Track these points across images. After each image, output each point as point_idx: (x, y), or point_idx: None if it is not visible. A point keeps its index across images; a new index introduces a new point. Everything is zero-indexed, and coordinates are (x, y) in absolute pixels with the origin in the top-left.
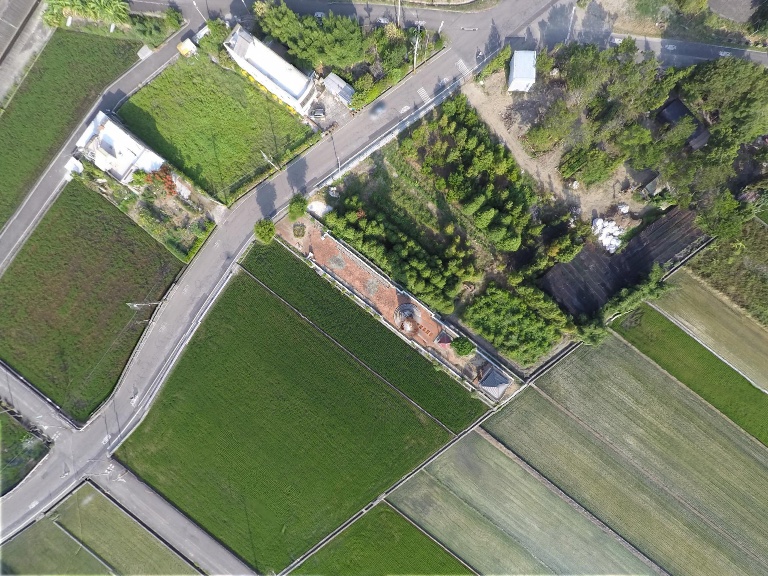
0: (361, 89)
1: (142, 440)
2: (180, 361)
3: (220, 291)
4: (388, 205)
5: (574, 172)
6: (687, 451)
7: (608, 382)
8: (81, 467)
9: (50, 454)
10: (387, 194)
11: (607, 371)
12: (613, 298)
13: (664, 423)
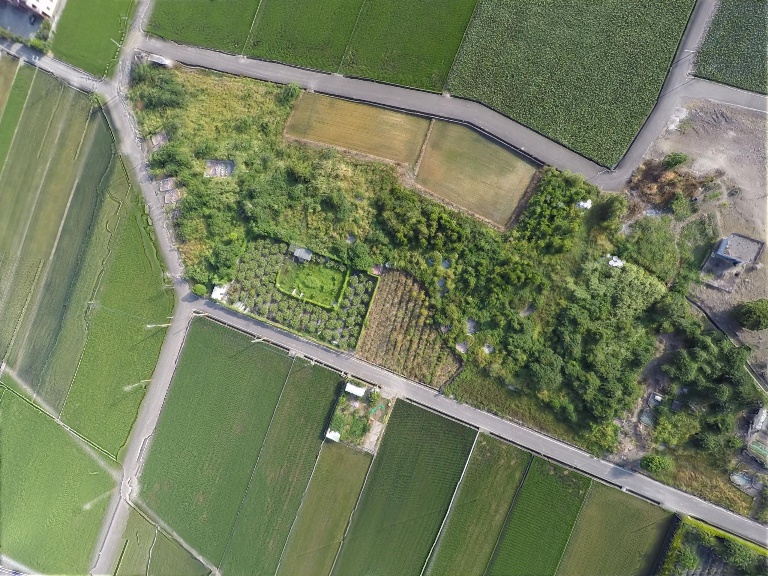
0: None
1: None
2: (14, 568)
3: None
4: None
5: None
6: None
7: None
8: None
9: None
10: None
11: None
12: None
13: None
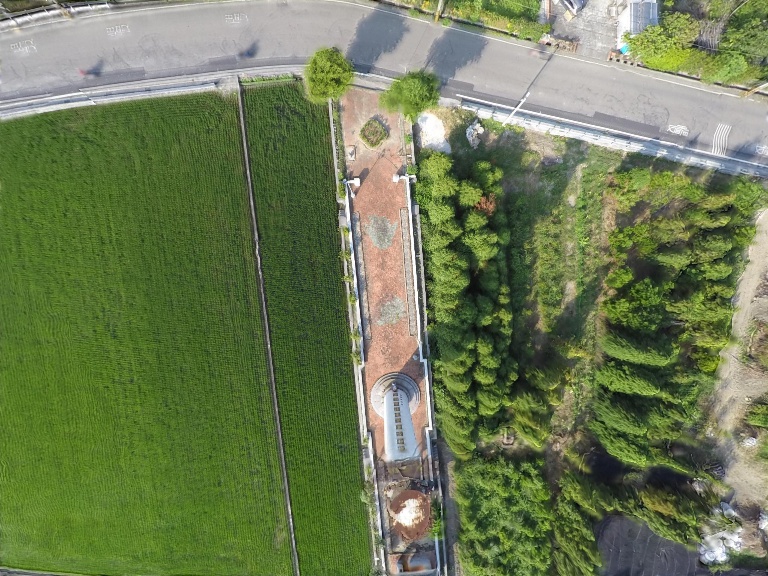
0: (672, 31)
1: None
2: (2, 125)
3: (171, 90)
4: (525, 230)
5: (762, 425)
6: None
7: None
8: None
9: None
10: (537, 214)
11: None
12: None
13: None
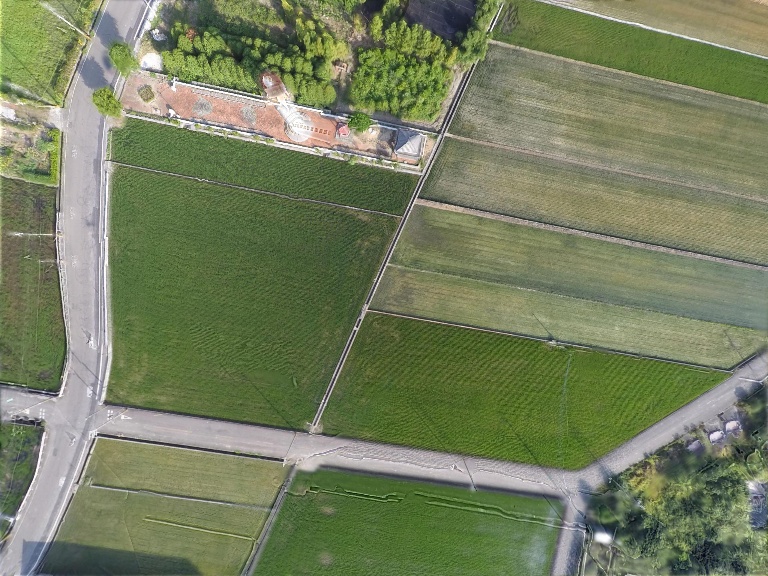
0: None
1: (123, 375)
2: (111, 284)
3: (107, 197)
4: (218, 19)
5: None
6: (611, 125)
7: (514, 96)
8: (83, 428)
9: (47, 432)
10: (212, 9)
11: (510, 87)
12: (478, 0)
13: (581, 109)
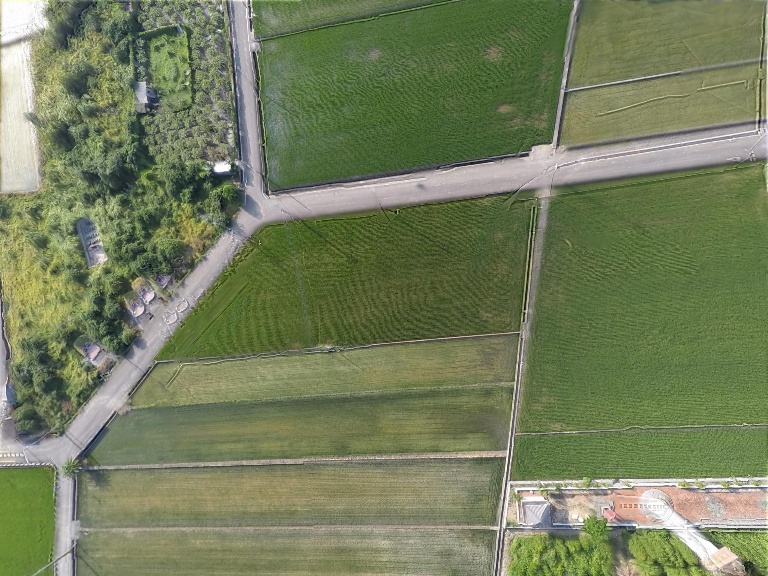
0: None
1: (753, 199)
2: None
3: None
4: None
5: None
6: (341, 571)
7: None
8: None
9: None
10: None
11: None
12: None
13: None
